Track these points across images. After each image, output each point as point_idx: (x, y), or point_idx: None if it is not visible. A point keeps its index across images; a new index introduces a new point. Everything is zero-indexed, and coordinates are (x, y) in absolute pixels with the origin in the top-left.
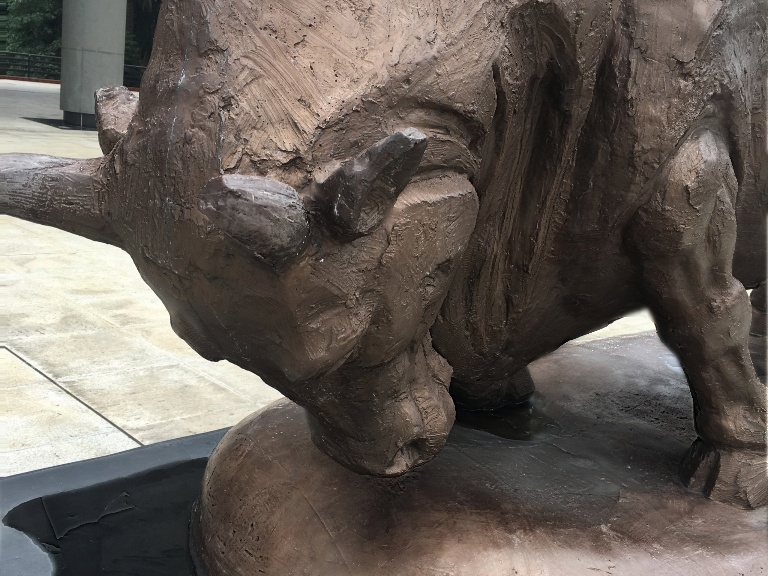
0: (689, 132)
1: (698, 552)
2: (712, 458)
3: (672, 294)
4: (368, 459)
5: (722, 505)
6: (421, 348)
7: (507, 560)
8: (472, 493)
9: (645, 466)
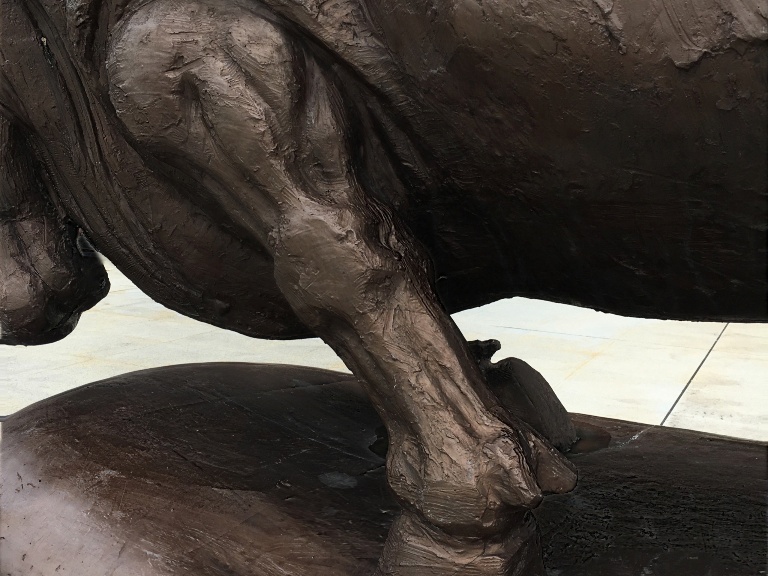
0: (116, 1)
1: (151, 553)
2: None
3: (233, 217)
4: None
5: None
6: (1, 232)
7: (3, 438)
8: (94, 403)
9: None
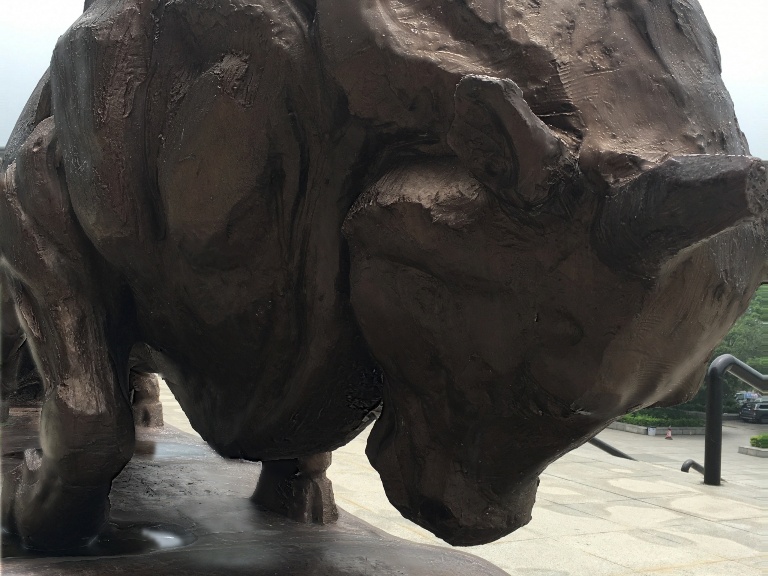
0: None
1: None
2: (312, 489)
3: None
4: (526, 510)
5: (329, 526)
6: None
7: None
8: (412, 552)
9: (269, 521)
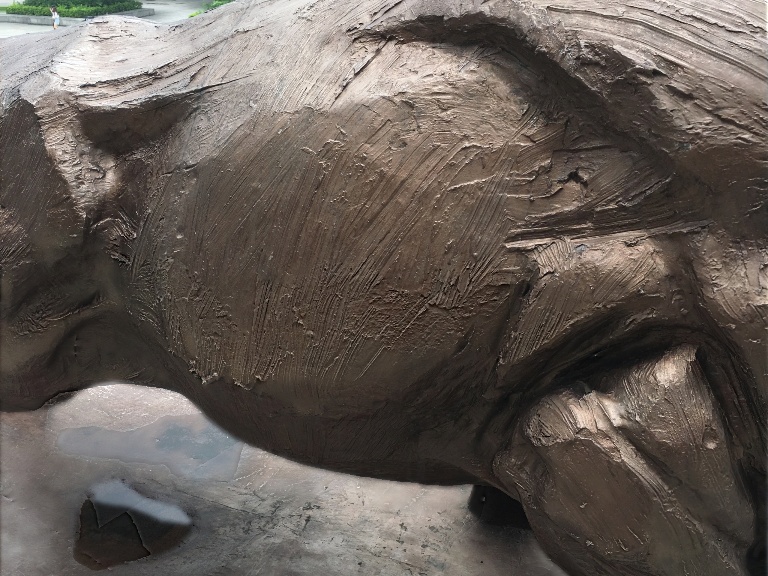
0: None
1: None
2: None
3: None
4: None
5: None
6: None
7: None
8: None
9: None
